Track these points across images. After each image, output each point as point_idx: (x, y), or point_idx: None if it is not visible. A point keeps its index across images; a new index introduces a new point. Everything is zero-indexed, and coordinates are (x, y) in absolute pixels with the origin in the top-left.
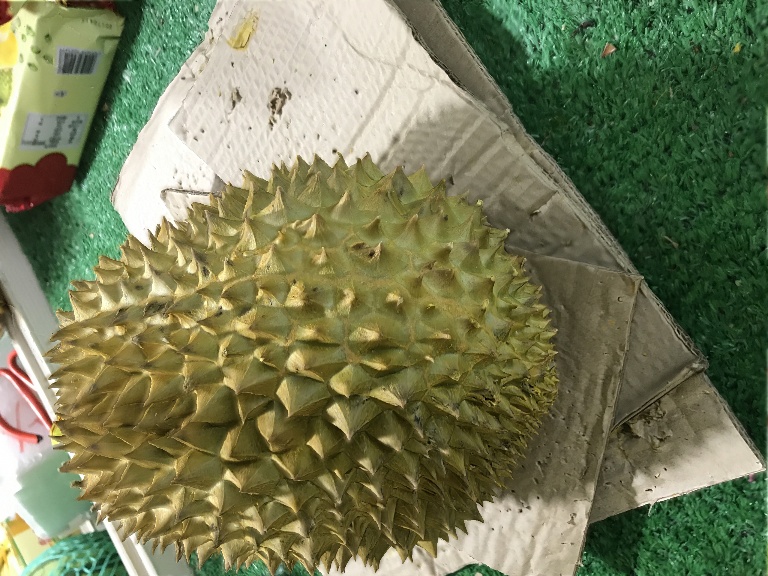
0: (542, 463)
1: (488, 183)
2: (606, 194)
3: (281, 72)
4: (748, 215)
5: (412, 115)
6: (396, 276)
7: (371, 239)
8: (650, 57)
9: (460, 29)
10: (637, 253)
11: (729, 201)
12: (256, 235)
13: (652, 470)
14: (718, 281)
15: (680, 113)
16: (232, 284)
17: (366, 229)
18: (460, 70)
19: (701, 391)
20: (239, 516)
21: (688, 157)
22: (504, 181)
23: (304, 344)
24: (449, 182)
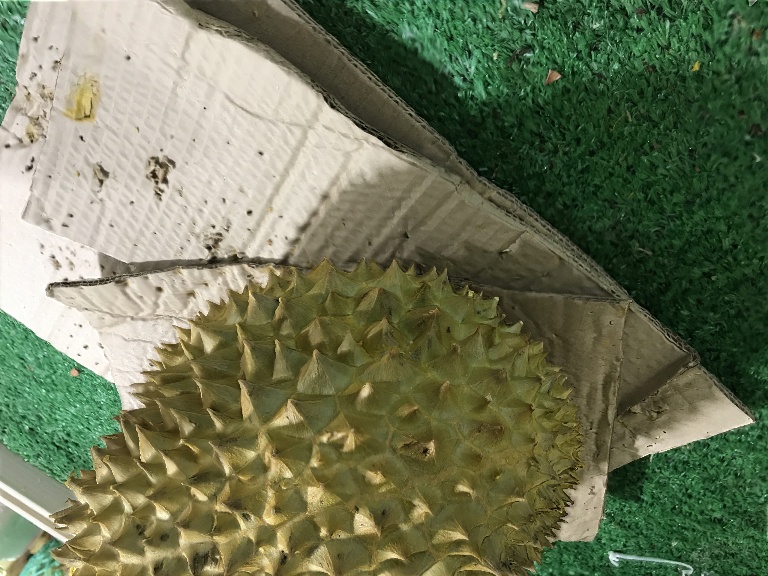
0: None
1: (449, 234)
2: (572, 217)
3: (152, 140)
4: (719, 221)
5: (340, 174)
6: (452, 458)
7: (411, 425)
8: (600, 81)
9: (368, 65)
10: (611, 264)
11: (700, 212)
12: (288, 464)
13: (652, 434)
14: (694, 279)
15: (640, 134)
16: (287, 528)
17: (404, 419)
18: (385, 118)
19: (692, 374)
20: None
21: (654, 175)
22: (466, 230)
23: (388, 562)
24: (403, 237)
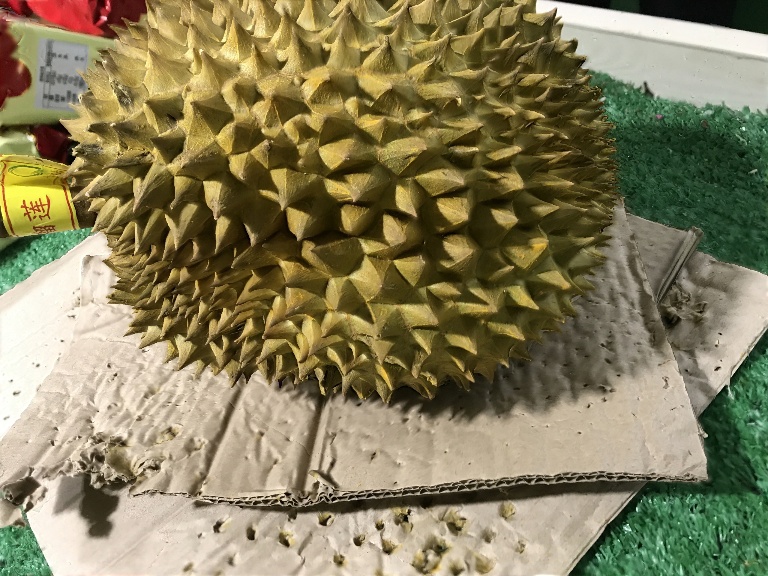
0: (606, 345)
1: None
2: None
3: None
4: None
5: None
6: None
7: None
8: None
9: None
10: None
11: (651, 179)
12: None
13: (709, 341)
14: (671, 217)
15: None
16: None
17: None
18: None
19: (708, 262)
20: (409, 42)
21: None
22: None
23: None
24: None
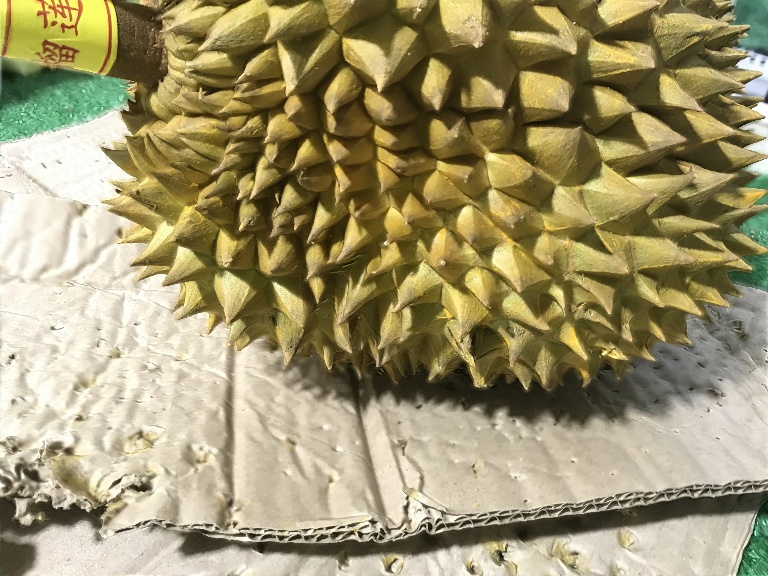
0: (688, 349)
1: None
2: None
3: None
4: None
5: None
6: None
7: None
8: None
9: None
10: None
11: None
12: None
13: (758, 357)
14: None
15: None
16: None
17: None
18: None
19: None
20: None
21: None
22: None
23: None
24: None
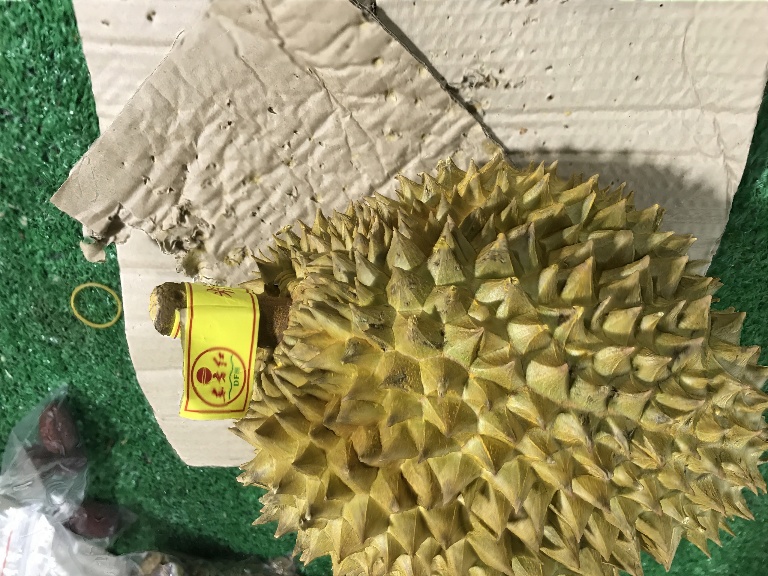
0: None
1: None
2: None
3: None
4: None
5: (666, 153)
6: None
7: None
8: None
9: None
10: None
11: None
12: None
13: None
14: None
15: None
16: (710, 449)
17: None
18: None
19: None
20: None
21: (767, 319)
22: None
23: None
24: None
